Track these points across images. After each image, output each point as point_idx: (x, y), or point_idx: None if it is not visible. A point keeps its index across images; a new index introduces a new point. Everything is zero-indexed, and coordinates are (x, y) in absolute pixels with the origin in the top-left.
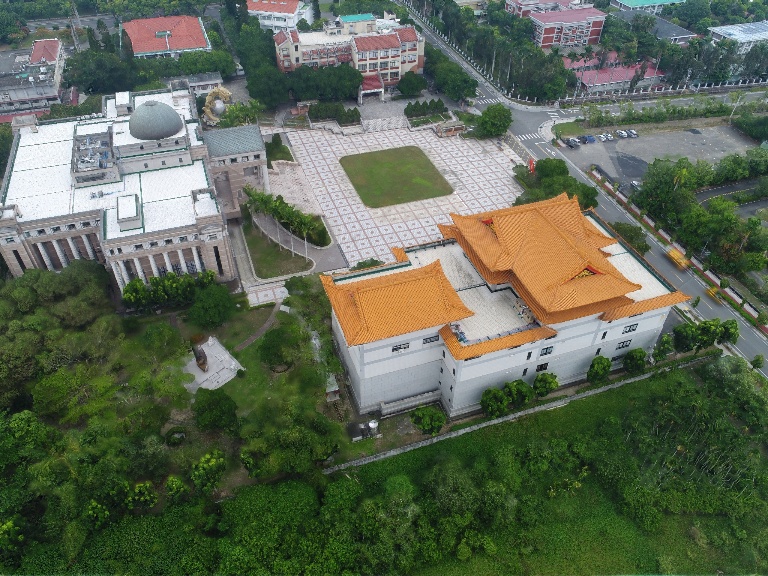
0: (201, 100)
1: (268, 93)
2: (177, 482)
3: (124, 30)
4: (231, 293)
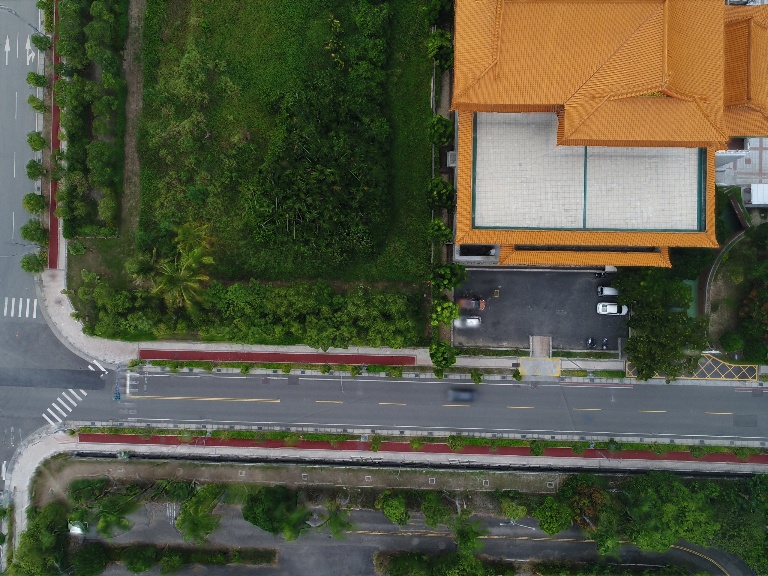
0: None
1: None
2: None
3: None
4: None
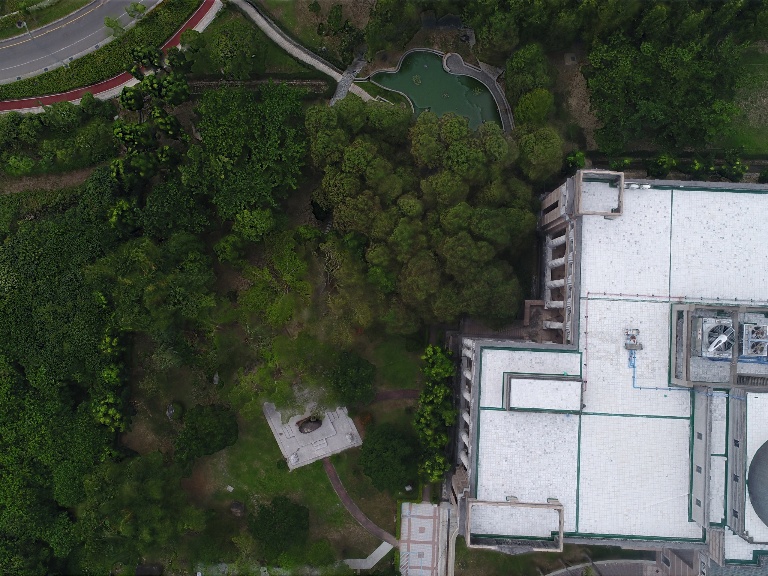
0: None
1: None
2: (110, 379)
3: None
4: (445, 482)
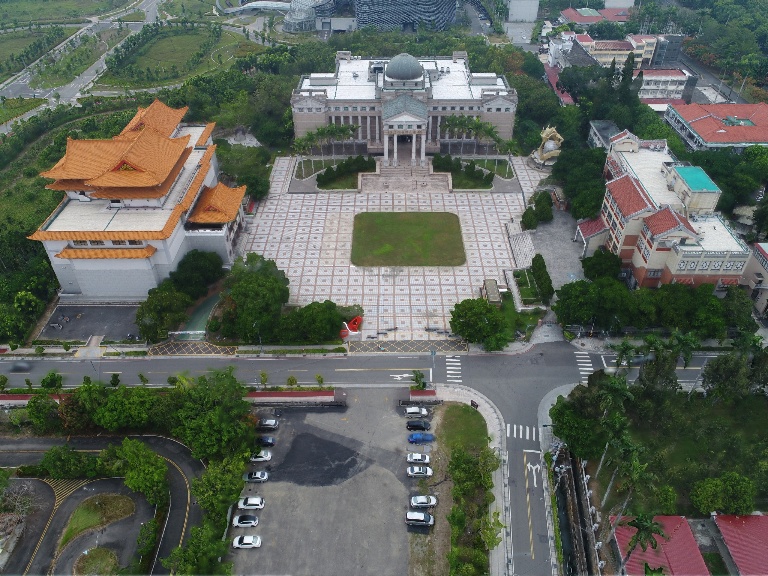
0: (570, 141)
1: (558, 160)
2: None
3: (641, 72)
4: None
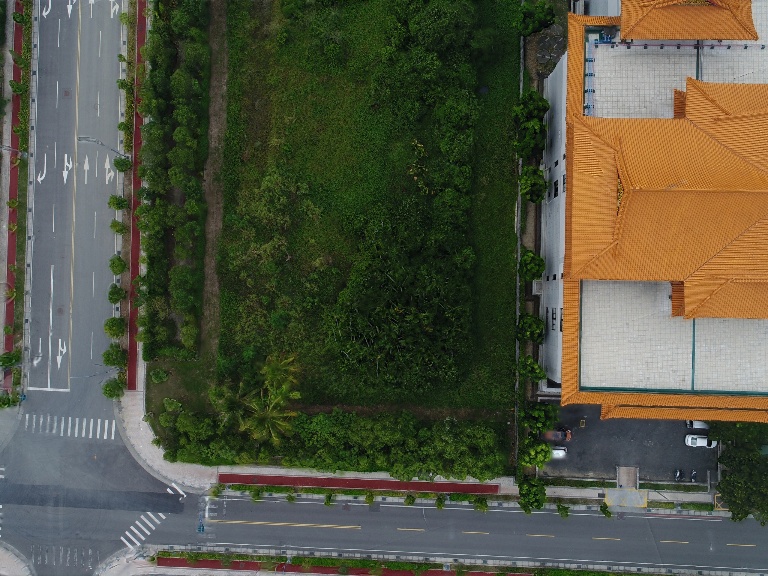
0: None
1: None
2: None
3: None
4: None
